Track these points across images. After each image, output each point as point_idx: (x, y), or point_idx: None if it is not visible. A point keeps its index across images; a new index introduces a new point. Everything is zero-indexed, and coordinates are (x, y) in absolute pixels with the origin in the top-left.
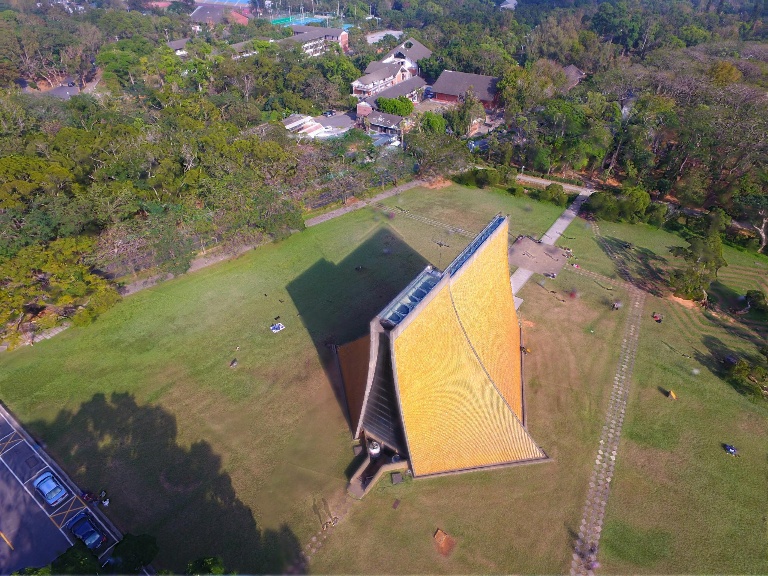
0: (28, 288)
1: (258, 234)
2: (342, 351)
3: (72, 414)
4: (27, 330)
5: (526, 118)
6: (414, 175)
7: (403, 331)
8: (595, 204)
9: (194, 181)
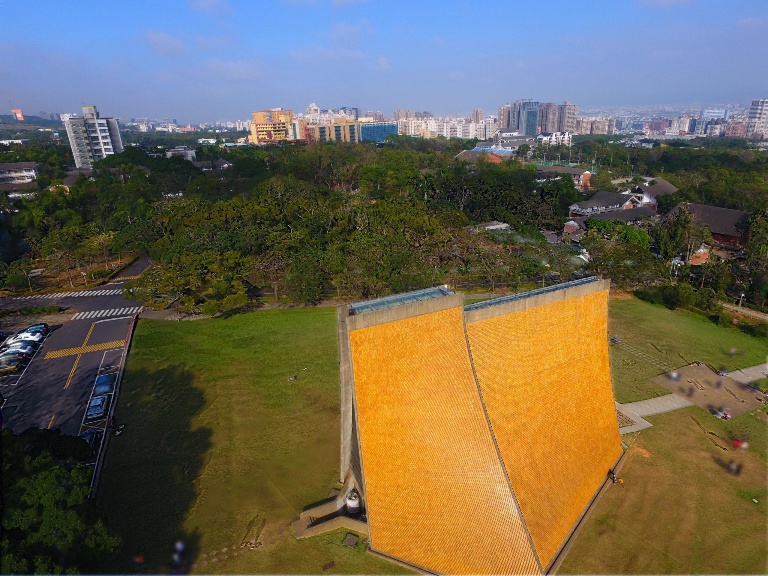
0: None
1: (381, 286)
2: None
3: (157, 368)
4: (184, 312)
5: None
6: None
7: (368, 327)
8: None
9: None
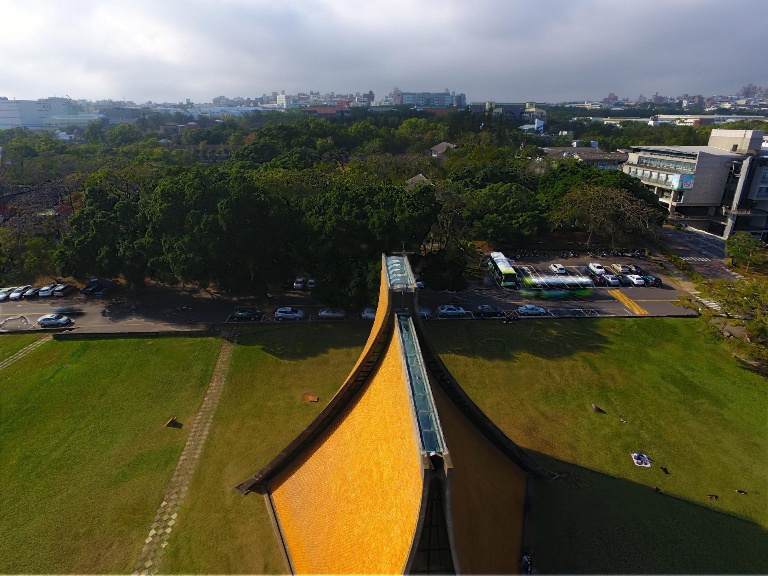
0: None
1: None
2: None
3: (598, 331)
4: None
5: None
6: None
7: None
8: None
9: None
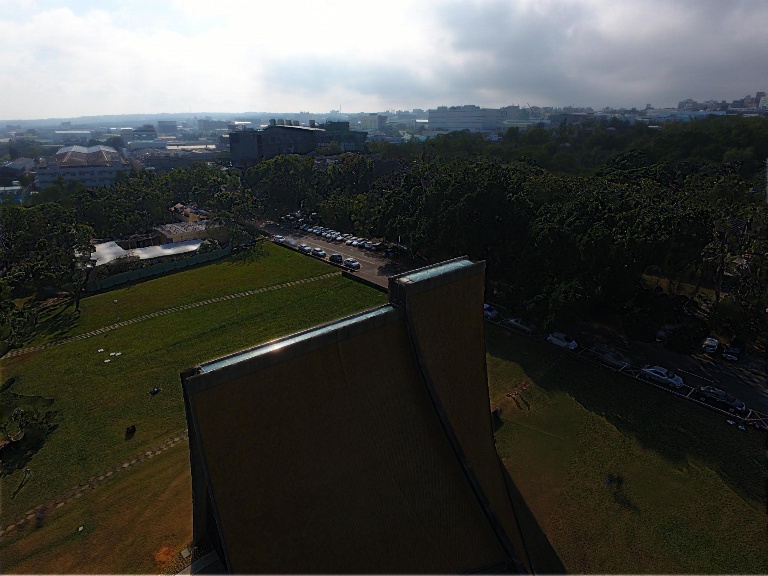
0: None
1: None
2: None
3: None
4: None
5: None
6: None
7: None
8: None
9: None
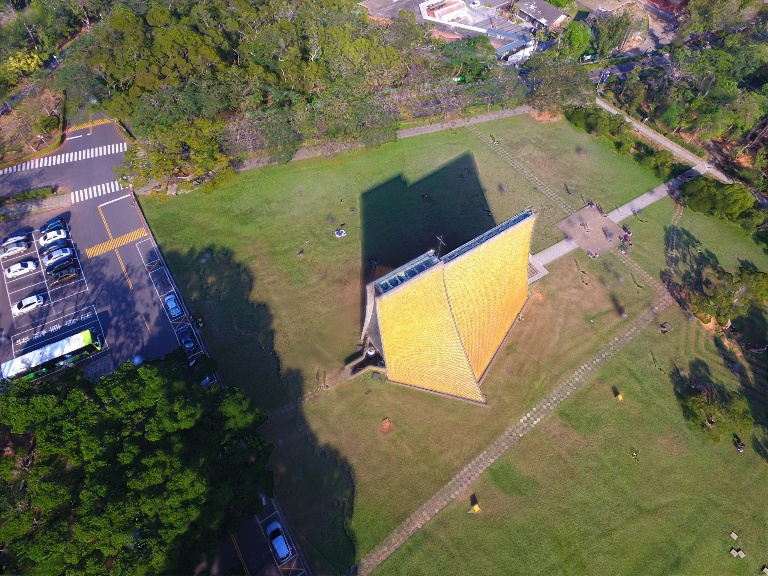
0: (177, 155)
1: (350, 144)
2: (378, 271)
3: (192, 258)
4: (174, 182)
5: (689, 52)
6: (528, 98)
7: (388, 297)
8: (690, 190)
9: (313, 75)
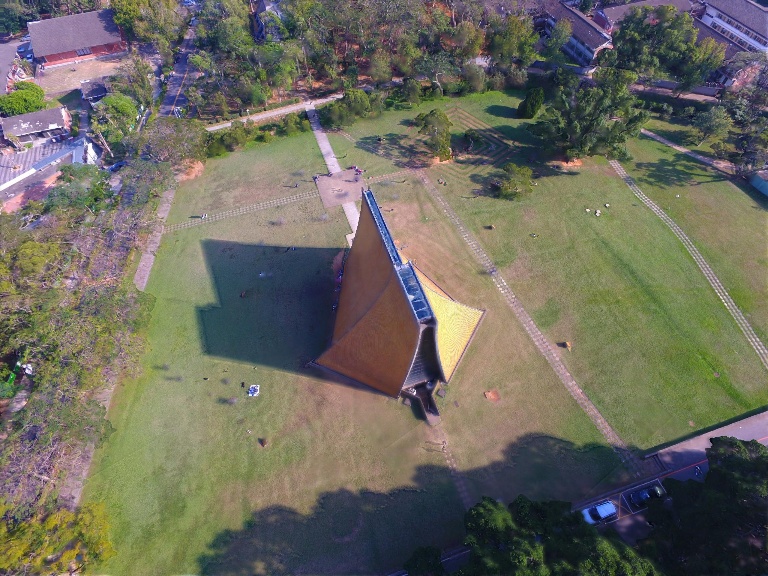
0: None
1: (137, 340)
2: (324, 361)
3: None
4: None
5: (198, 55)
6: None
7: None
8: (336, 118)
9: None
